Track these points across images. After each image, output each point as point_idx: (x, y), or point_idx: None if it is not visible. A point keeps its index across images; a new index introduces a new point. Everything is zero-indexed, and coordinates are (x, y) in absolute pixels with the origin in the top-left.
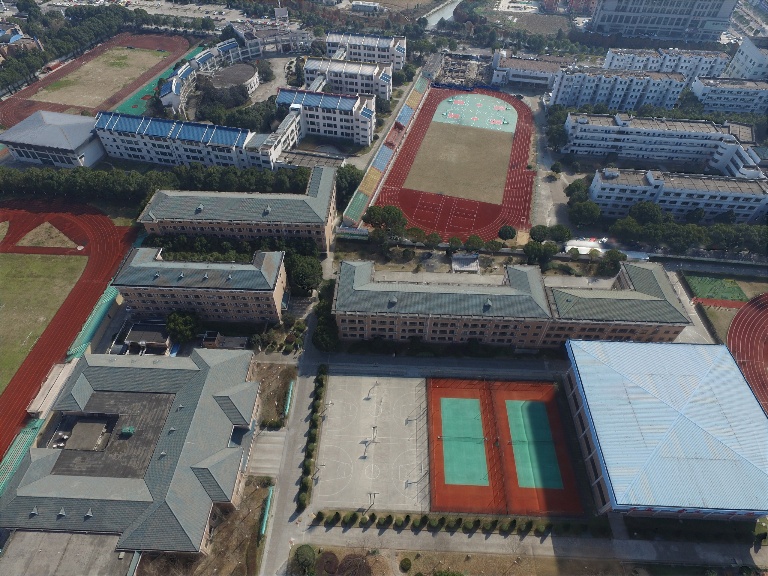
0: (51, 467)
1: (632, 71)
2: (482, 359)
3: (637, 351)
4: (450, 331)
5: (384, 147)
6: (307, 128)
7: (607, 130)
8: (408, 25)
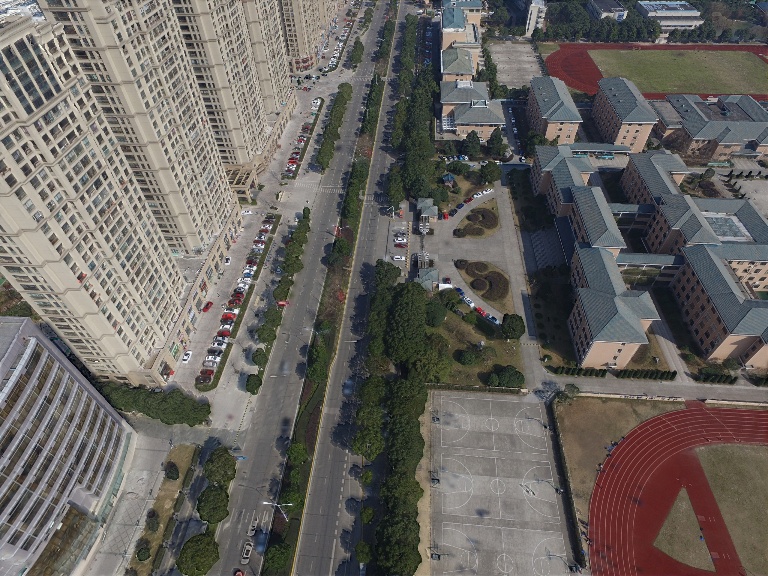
0: (696, 101)
1: None
2: None
3: None
4: None
5: None
6: None
7: None
8: None
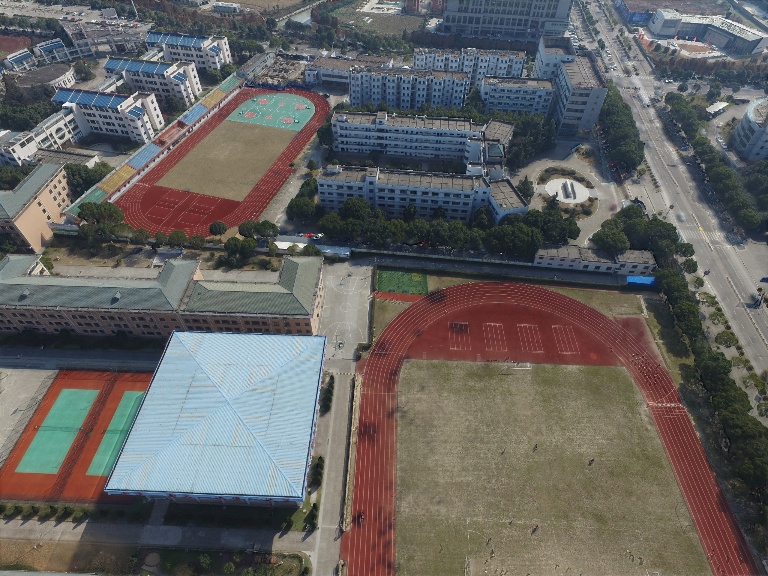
0: None
1: (417, 70)
2: (127, 351)
3: (233, 342)
4: (95, 324)
5: (151, 145)
6: (90, 126)
7: (367, 128)
8: (251, 26)
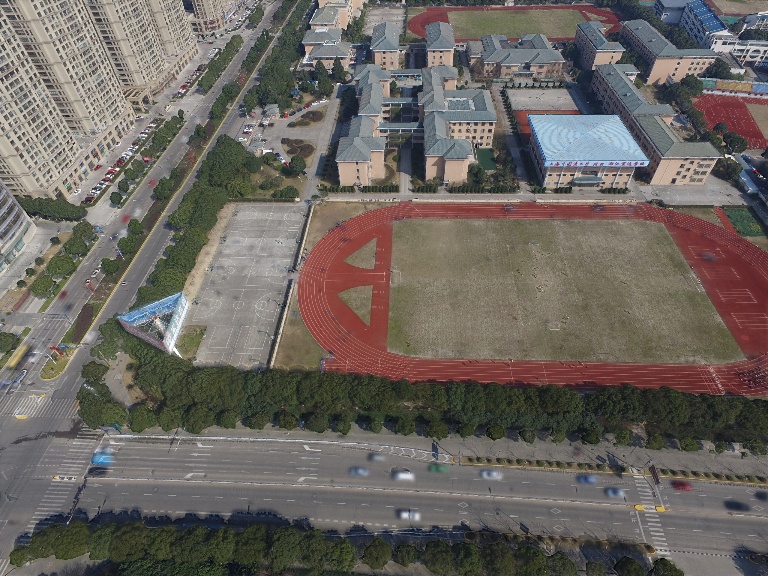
0: (501, 40)
1: None
2: None
3: (622, 131)
4: None
5: None
6: None
7: None
8: None
